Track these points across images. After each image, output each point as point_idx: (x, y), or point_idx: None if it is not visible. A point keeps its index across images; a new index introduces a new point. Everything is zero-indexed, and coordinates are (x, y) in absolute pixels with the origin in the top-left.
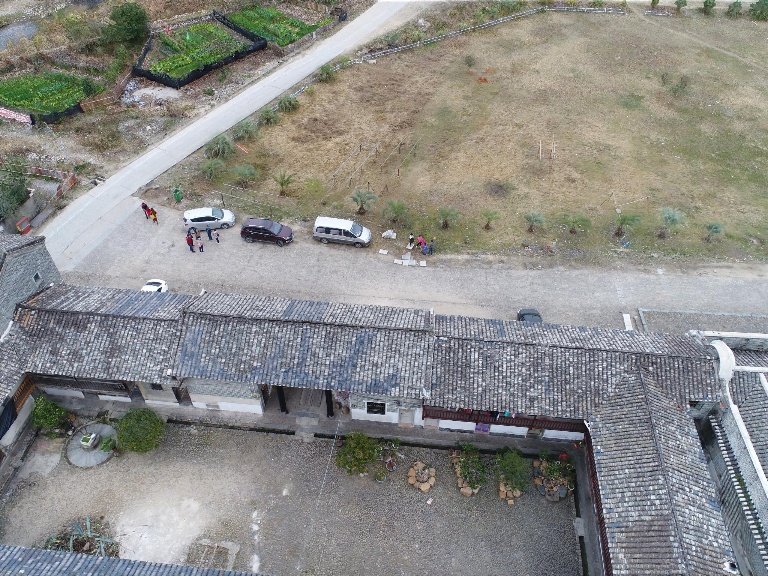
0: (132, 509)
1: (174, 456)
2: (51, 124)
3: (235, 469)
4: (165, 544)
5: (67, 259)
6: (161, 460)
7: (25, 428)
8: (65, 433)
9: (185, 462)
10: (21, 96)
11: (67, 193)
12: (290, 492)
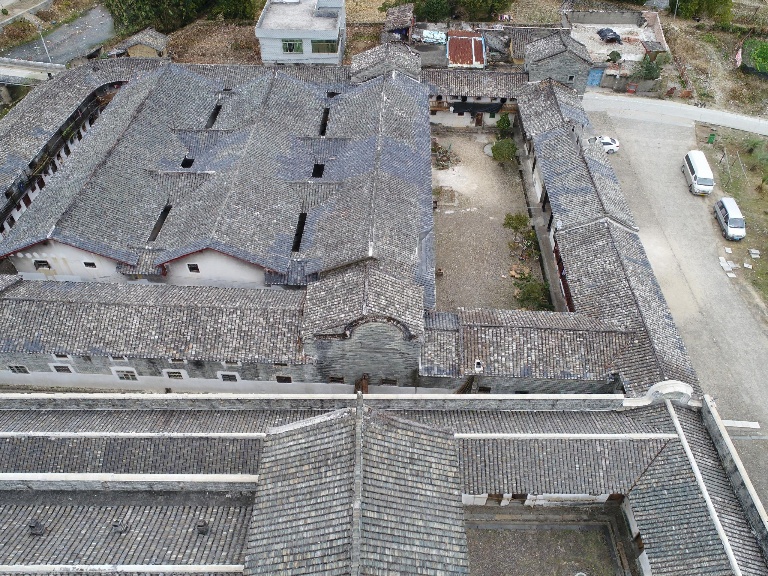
0: (467, 169)
1: (500, 176)
2: (742, 73)
3: (499, 198)
4: (452, 182)
5: (618, 112)
6: (496, 173)
7: (498, 128)
8: (500, 139)
9: (498, 181)
10: (765, 56)
11: (676, 97)
12: (492, 220)
